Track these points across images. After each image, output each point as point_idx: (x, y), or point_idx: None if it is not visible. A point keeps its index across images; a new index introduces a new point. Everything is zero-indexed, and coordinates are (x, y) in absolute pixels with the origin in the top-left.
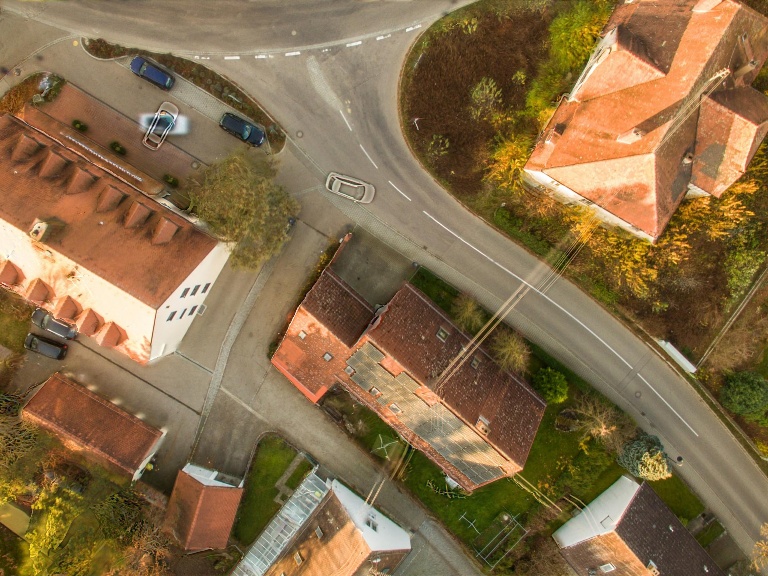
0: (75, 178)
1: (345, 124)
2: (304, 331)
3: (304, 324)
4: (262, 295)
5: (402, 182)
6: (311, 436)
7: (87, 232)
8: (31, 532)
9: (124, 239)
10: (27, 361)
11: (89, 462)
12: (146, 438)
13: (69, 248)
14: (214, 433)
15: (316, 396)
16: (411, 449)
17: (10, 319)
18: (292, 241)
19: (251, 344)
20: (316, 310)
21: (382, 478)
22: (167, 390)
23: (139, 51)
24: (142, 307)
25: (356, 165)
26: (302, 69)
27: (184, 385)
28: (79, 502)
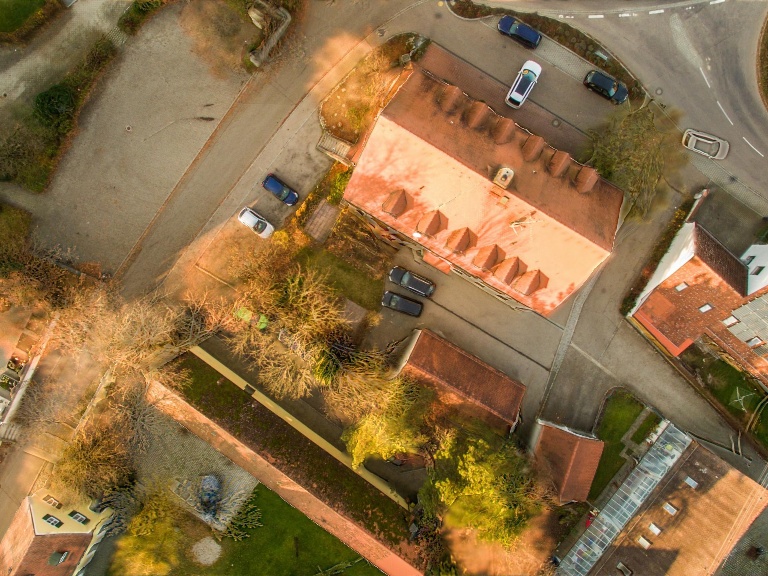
0: (506, 128)
1: (704, 81)
2: (686, 282)
3: (690, 275)
4: (617, 251)
5: (756, 138)
6: (658, 391)
7: (529, 180)
8: (444, 480)
9: (557, 187)
10: (382, 319)
11: (460, 416)
12: (515, 392)
13: (524, 194)
14: (563, 389)
15: (680, 349)
16: (767, 401)
17: (364, 278)
18: (656, 196)
19: (603, 300)
20: (707, 260)
21: (736, 430)
22: (517, 347)
23: (505, 10)
24: (595, 251)
25: (712, 122)
26: (665, 27)
27: (535, 341)
28: (487, 451)
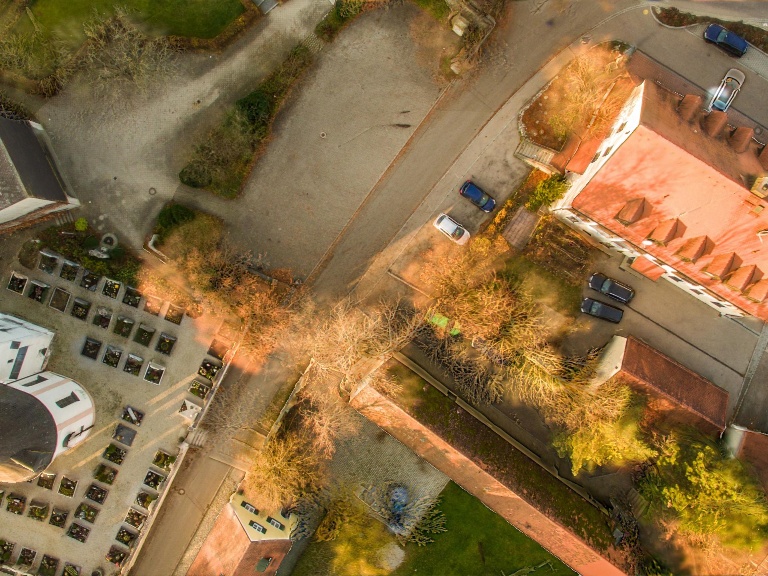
0: (747, 137)
1: None
2: None
3: None
4: None
5: None
6: None
7: None
8: (673, 486)
9: None
10: None
11: (667, 422)
12: (720, 398)
13: None
14: (757, 394)
15: None
16: None
17: (562, 284)
18: None
19: None
20: None
21: None
22: (712, 353)
23: (711, 19)
24: None
25: None
26: None
27: (730, 348)
28: (714, 457)
